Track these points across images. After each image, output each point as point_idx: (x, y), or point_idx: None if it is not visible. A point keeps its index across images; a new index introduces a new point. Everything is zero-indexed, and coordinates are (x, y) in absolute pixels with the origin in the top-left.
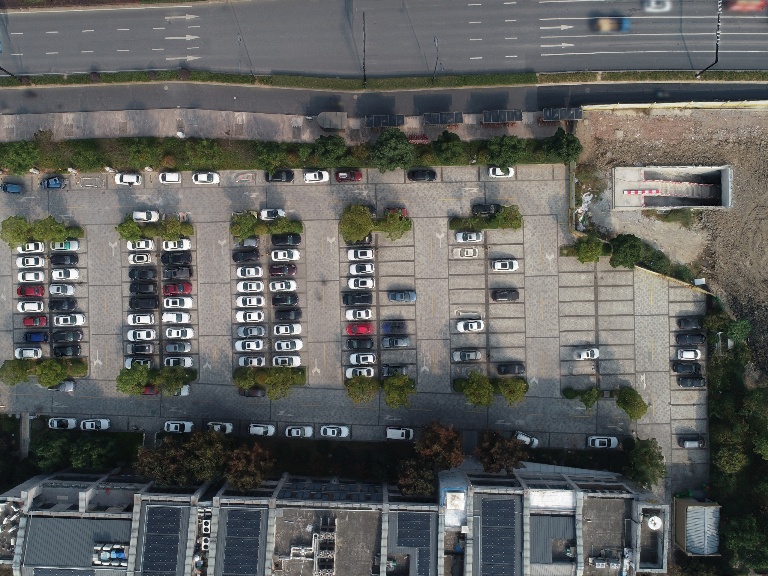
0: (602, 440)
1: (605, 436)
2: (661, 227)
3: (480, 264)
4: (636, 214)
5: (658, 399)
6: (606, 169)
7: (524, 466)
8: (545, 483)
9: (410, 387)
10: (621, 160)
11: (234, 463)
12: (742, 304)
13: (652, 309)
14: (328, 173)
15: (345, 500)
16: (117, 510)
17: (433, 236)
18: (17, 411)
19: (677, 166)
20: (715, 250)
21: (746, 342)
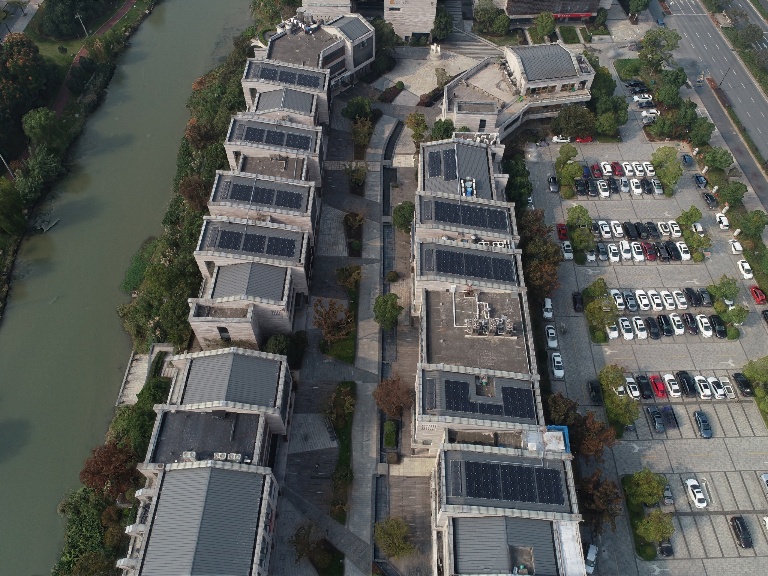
0: None
1: None
2: None
3: (764, 504)
4: None
5: None
6: None
7: None
8: None
9: (619, 430)
10: None
11: (546, 267)
12: None
13: None
14: None
15: None
16: None
17: None
18: (528, 163)
19: None
20: None
21: None
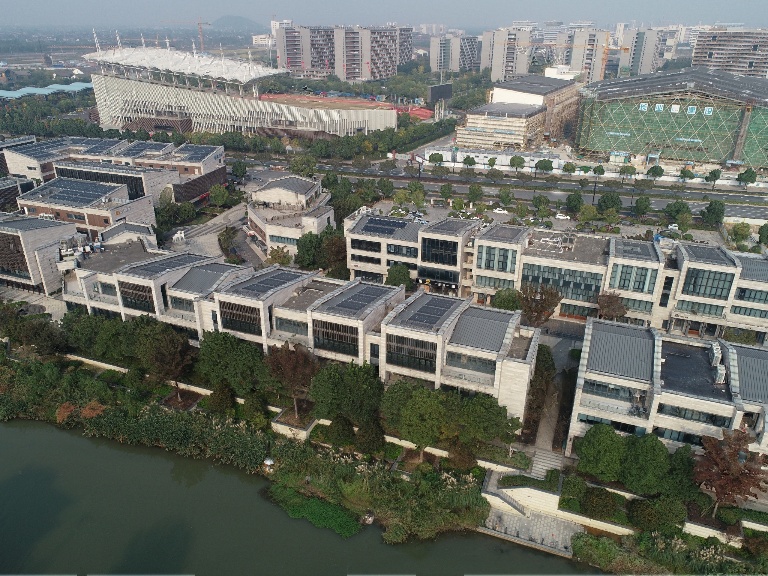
0: None
1: None
2: None
3: None
4: None
5: None
6: None
7: None
8: None
9: None
10: None
11: None
12: None
13: None
14: None
15: None
16: None
17: None
18: None
19: None
20: None
21: None
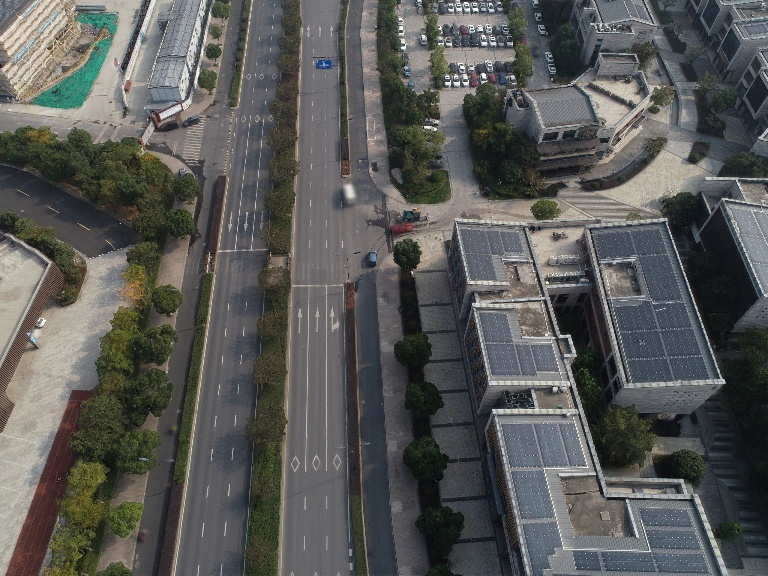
0: None
1: None
2: None
3: None
4: None
5: None
6: None
7: None
8: None
9: None
10: None
11: None
12: None
13: None
14: None
15: None
16: (590, 5)
17: None
18: None
19: None
20: None
21: None
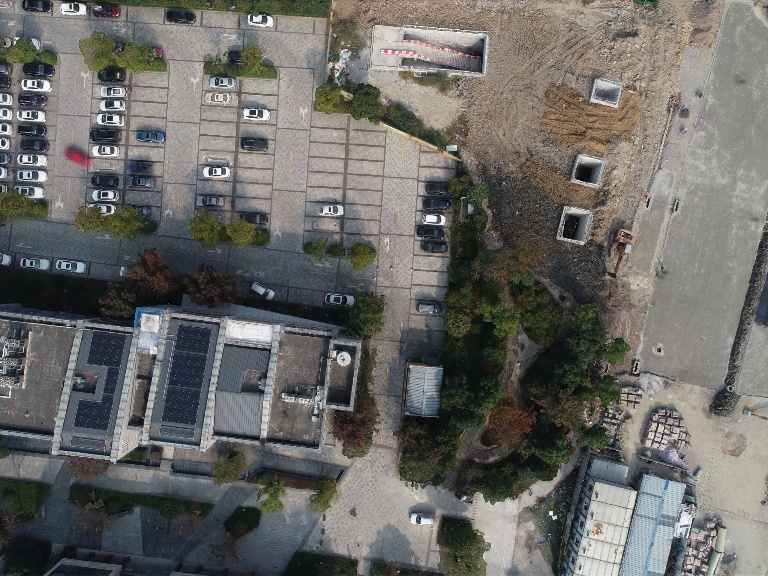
0: (337, 296)
1: (343, 294)
2: (418, 90)
3: (233, 112)
4: (393, 75)
5: (400, 263)
6: (367, 27)
7: (233, 301)
8: (256, 322)
9: (148, 227)
10: (382, 19)
11: None
12: (491, 174)
13: (402, 172)
14: (86, 6)
15: (44, 316)
16: None
17: (188, 80)
18: None
19: (434, 27)
20: (469, 118)
21: (492, 212)
